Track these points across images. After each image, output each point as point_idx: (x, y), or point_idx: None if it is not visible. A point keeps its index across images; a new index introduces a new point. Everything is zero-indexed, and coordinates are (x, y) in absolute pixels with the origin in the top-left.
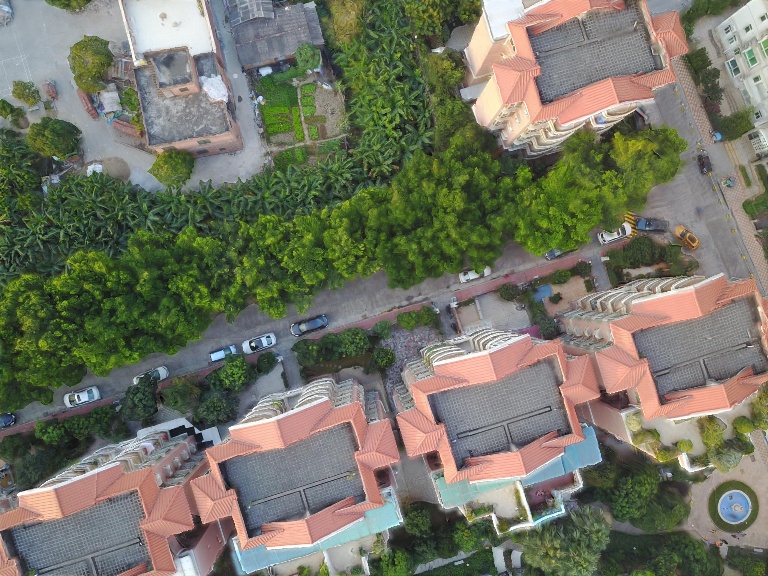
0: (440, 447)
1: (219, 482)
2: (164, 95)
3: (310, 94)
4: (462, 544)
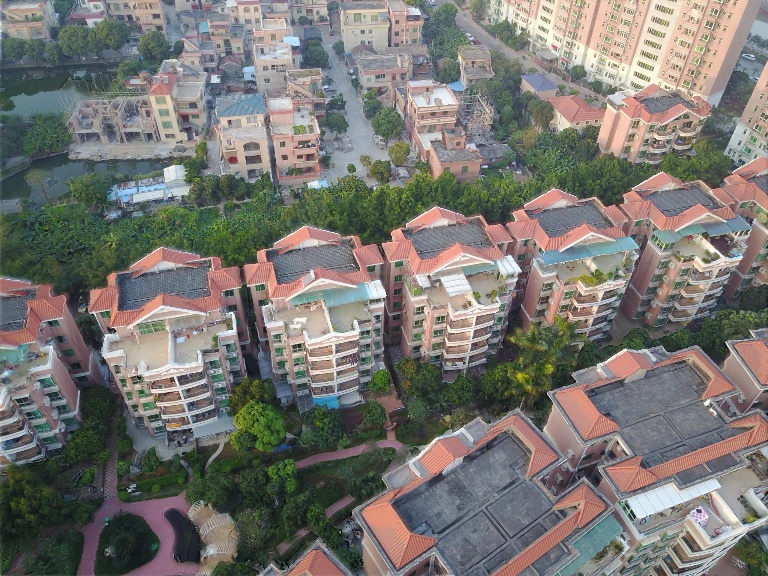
0: (651, 213)
1: (525, 219)
2: (447, 149)
3: (510, 175)
4: (679, 342)
